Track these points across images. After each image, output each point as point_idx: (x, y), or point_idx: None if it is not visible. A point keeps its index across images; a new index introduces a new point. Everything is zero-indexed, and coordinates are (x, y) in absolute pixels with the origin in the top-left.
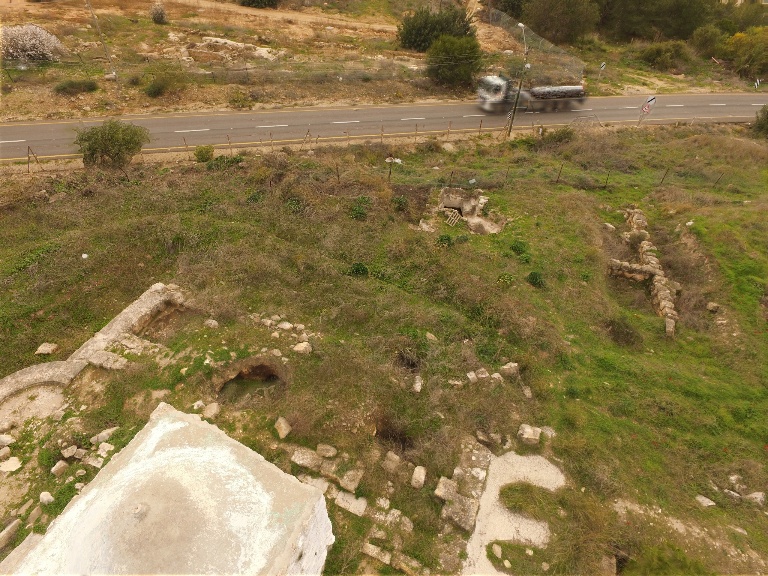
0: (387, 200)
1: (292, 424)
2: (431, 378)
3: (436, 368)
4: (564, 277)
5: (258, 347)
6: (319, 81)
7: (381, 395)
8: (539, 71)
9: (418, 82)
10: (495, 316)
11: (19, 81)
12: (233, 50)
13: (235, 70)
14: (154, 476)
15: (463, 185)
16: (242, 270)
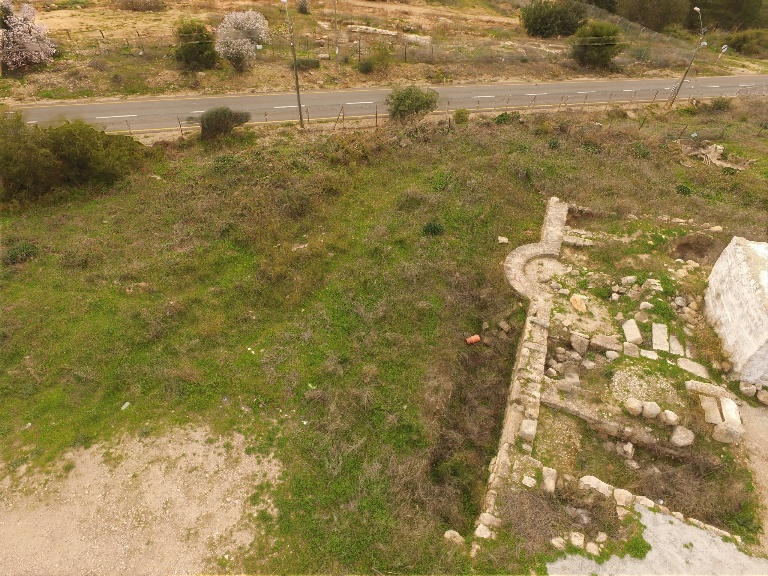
0: None
1: None
2: None
3: None
4: None
5: None
6: (488, 61)
7: None
8: (659, 54)
9: (567, 63)
10: None
11: None
12: None
13: None
14: None
15: (688, 138)
16: (606, 189)
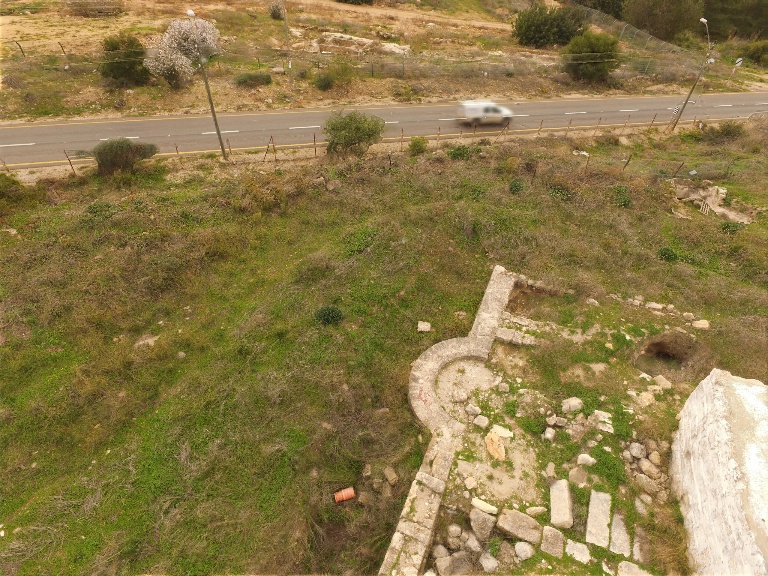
0: None
1: None
2: None
3: None
4: None
5: (659, 324)
6: (468, 76)
7: None
8: (665, 67)
9: (558, 77)
10: None
11: (197, 74)
12: (362, 45)
13: (461, 62)
14: None
15: (686, 176)
16: (567, 254)
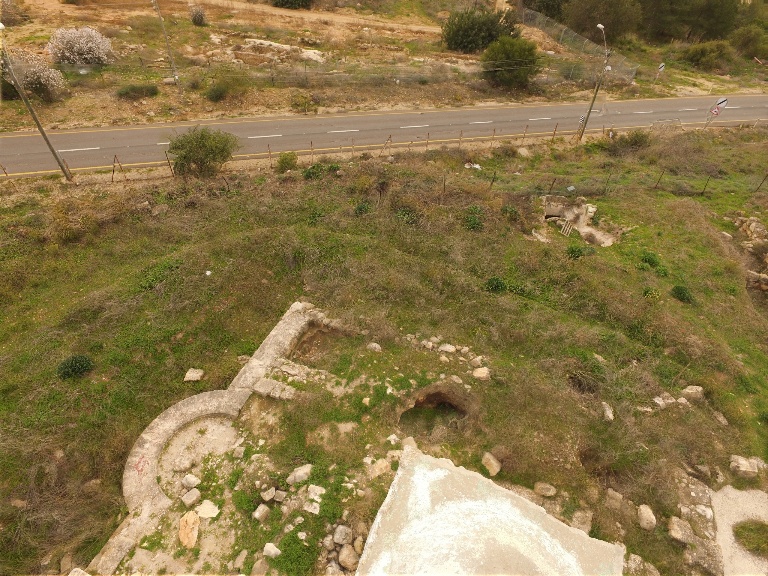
0: (499, 210)
1: (502, 460)
2: (620, 405)
3: (621, 393)
4: (709, 291)
5: (435, 373)
6: (377, 84)
7: (580, 425)
8: (592, 73)
9: (475, 84)
10: (659, 335)
11: (78, 85)
12: (280, 52)
13: None
14: (488, 544)
15: (562, 192)
16: (380, 287)
